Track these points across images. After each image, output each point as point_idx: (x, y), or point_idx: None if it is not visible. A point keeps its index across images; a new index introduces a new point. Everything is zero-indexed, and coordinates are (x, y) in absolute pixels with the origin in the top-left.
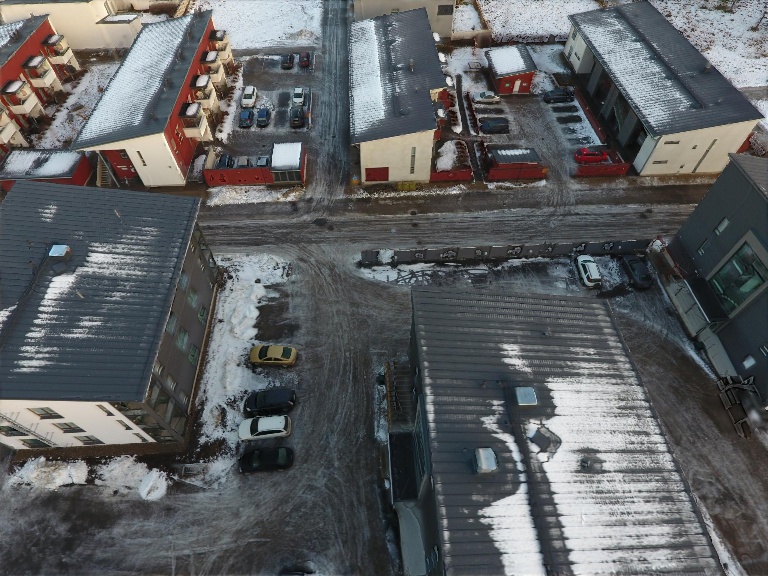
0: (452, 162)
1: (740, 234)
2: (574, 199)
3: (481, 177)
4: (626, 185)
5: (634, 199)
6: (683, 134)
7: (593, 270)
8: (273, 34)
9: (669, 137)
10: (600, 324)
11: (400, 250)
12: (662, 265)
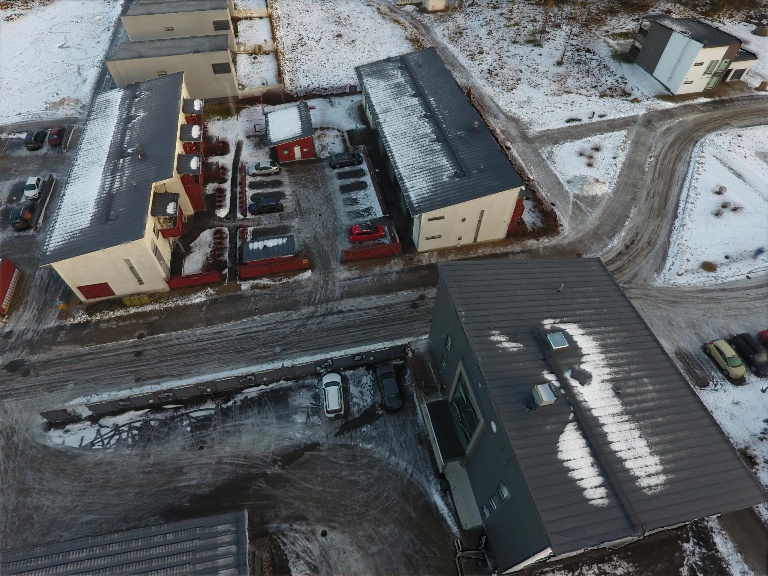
0: (204, 258)
1: (458, 359)
2: (340, 292)
3: (236, 275)
4: (401, 266)
5: (407, 284)
6: (444, 210)
7: (332, 398)
8: (31, 104)
9: (430, 214)
10: (216, 563)
11: (93, 403)
12: (422, 372)
